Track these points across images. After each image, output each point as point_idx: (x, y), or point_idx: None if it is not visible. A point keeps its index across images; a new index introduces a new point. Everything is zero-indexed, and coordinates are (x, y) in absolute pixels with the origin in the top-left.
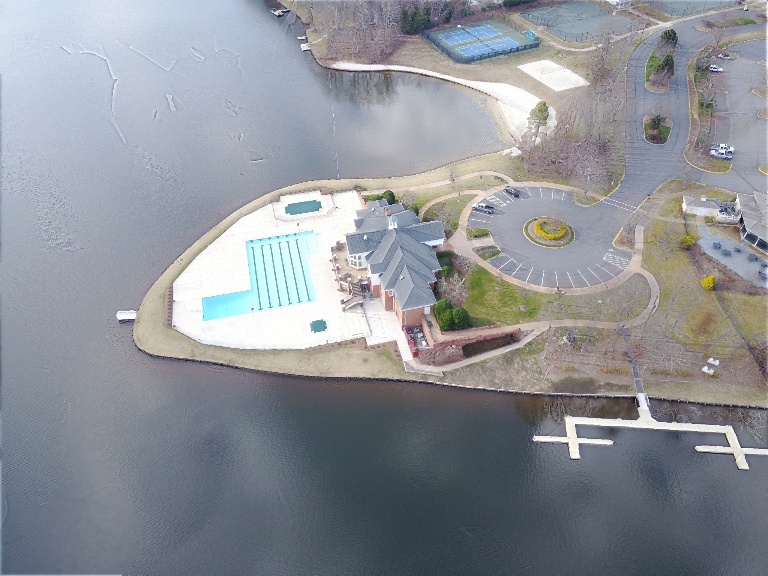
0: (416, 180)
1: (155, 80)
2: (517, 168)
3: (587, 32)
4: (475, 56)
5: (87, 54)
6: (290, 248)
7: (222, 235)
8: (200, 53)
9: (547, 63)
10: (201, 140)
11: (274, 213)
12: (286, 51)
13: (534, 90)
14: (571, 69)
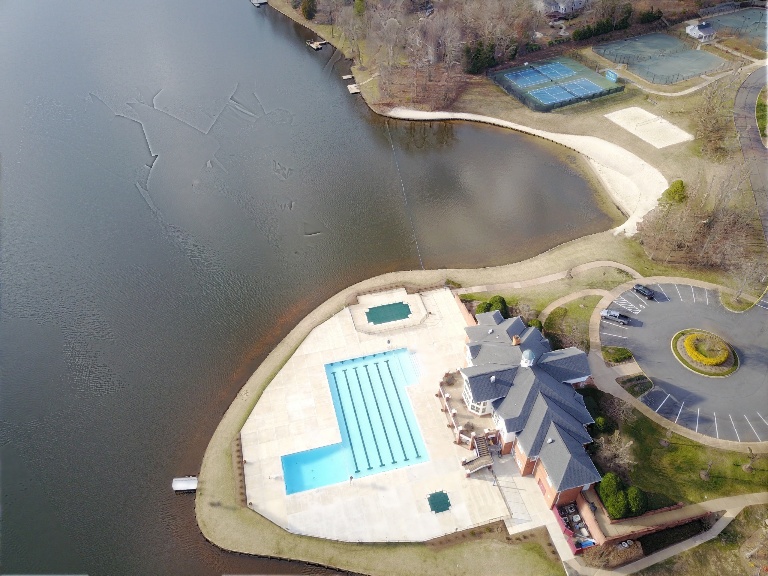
0: (519, 272)
1: (199, 150)
2: (638, 255)
3: (678, 73)
4: (555, 103)
5: (115, 117)
6: (381, 374)
7: (293, 355)
8: (243, 106)
9: (637, 111)
10: (247, 212)
11: (354, 322)
12: (332, 94)
13: (630, 146)
14: (667, 119)
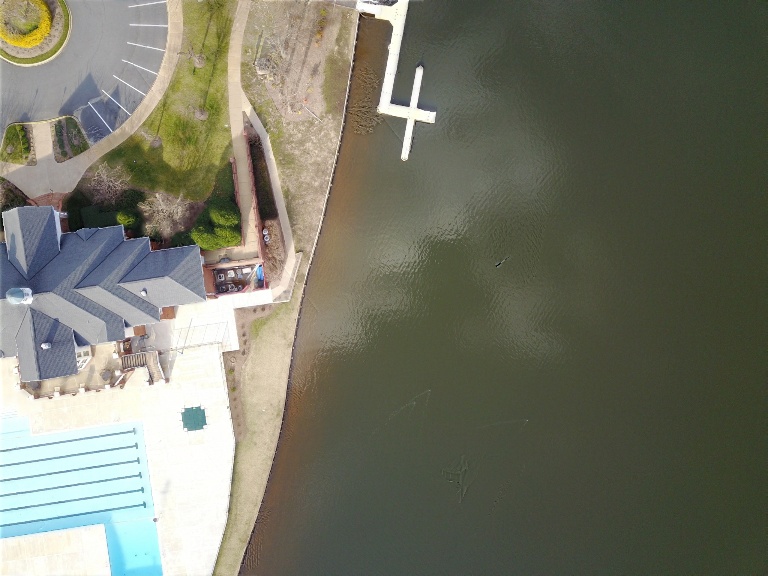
0: None
1: None
2: None
3: None
4: None
5: None
6: (6, 464)
7: None
8: None
9: None
10: None
11: None
12: None
13: None
14: None
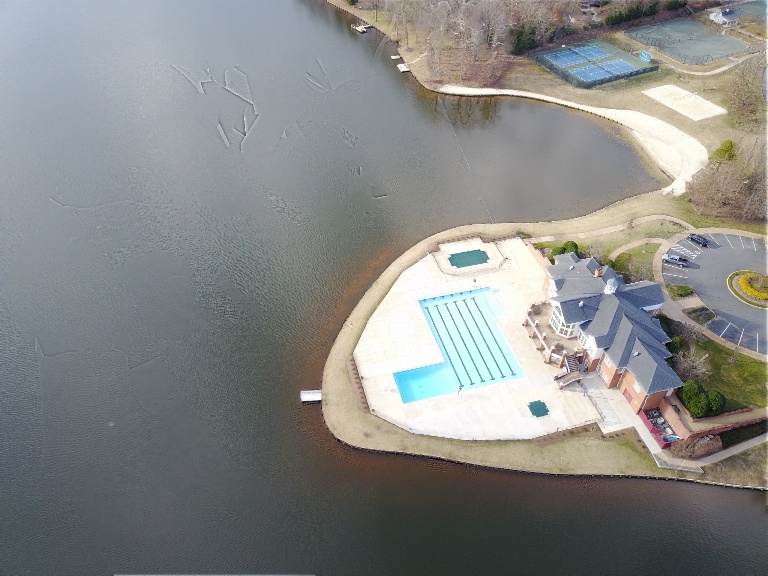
0: (582, 225)
1: (289, 113)
2: (688, 211)
3: (708, 54)
4: (596, 80)
5: (209, 83)
6: (470, 309)
7: (389, 293)
8: (313, 78)
9: (672, 88)
10: None
11: (439, 265)
12: (383, 72)
13: (669, 119)
14: (701, 95)
